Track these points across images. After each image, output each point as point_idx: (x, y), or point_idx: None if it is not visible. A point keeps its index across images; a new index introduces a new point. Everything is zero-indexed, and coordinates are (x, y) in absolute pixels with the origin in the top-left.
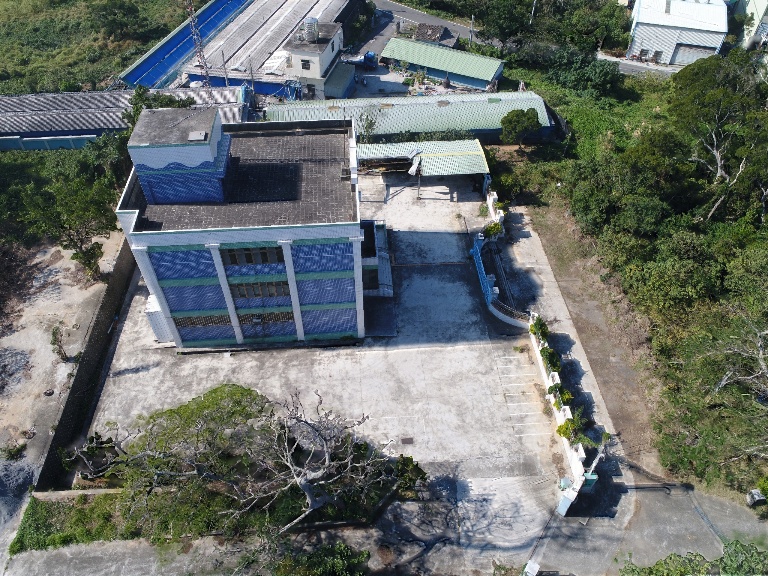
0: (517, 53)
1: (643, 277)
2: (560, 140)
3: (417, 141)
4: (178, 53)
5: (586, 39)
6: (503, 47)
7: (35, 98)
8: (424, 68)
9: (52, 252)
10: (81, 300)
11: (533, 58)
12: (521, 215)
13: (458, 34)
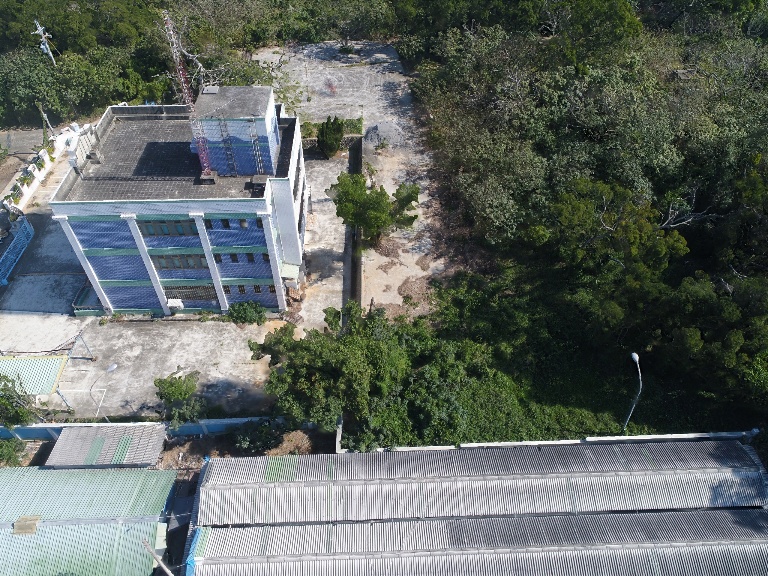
0: None
1: None
2: None
3: None
4: None
5: None
6: None
7: (629, 542)
8: None
9: (430, 269)
10: None
11: None
12: None
13: None
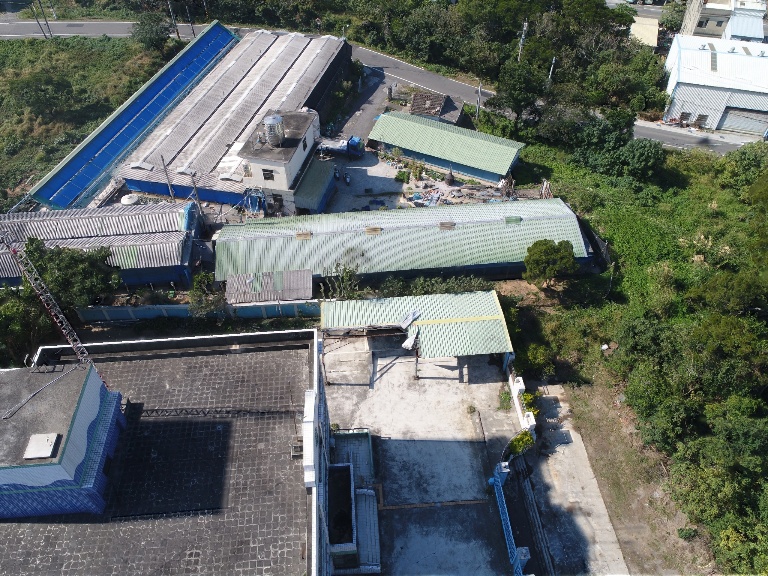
0: (535, 128)
1: (749, 555)
2: (599, 268)
3: (413, 292)
4: (113, 147)
5: (620, 112)
6: (517, 119)
7: None
8: (422, 159)
9: None
10: None
11: (555, 136)
12: (556, 401)
13: (462, 104)
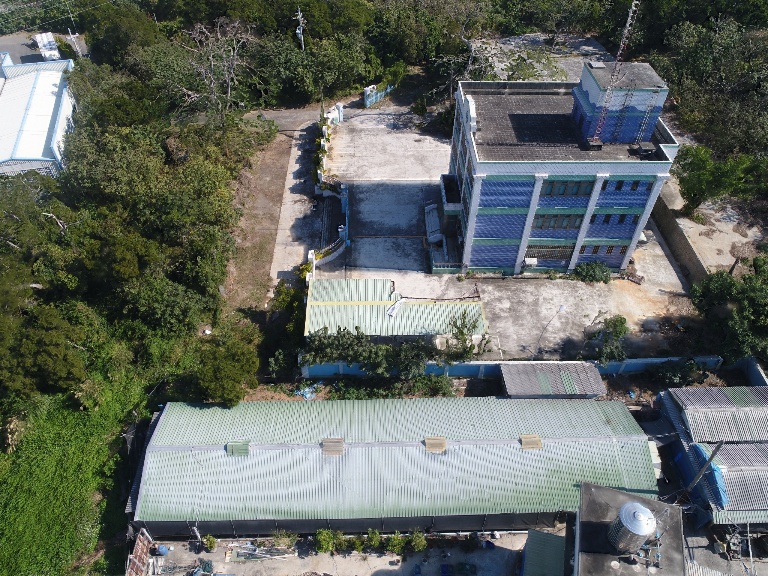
0: None
1: None
2: (146, 433)
3: None
4: None
5: None
6: None
7: None
8: None
9: (750, 236)
10: (680, 198)
11: None
12: None
13: None
